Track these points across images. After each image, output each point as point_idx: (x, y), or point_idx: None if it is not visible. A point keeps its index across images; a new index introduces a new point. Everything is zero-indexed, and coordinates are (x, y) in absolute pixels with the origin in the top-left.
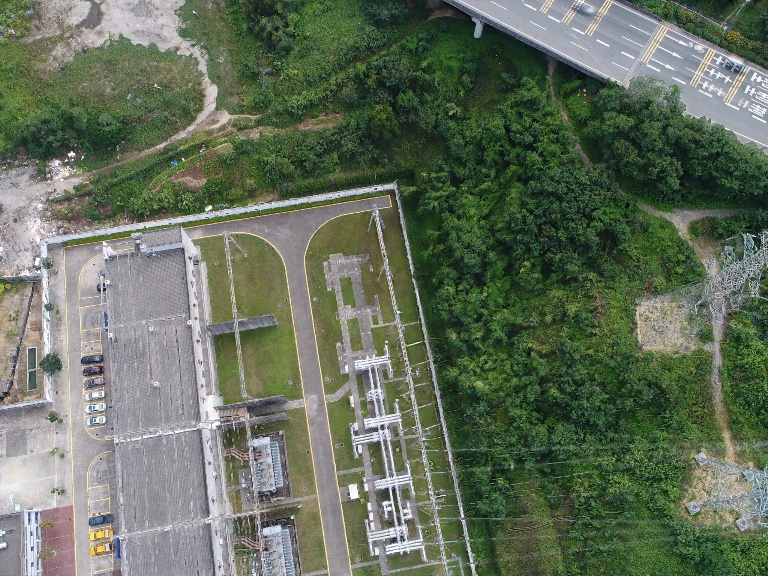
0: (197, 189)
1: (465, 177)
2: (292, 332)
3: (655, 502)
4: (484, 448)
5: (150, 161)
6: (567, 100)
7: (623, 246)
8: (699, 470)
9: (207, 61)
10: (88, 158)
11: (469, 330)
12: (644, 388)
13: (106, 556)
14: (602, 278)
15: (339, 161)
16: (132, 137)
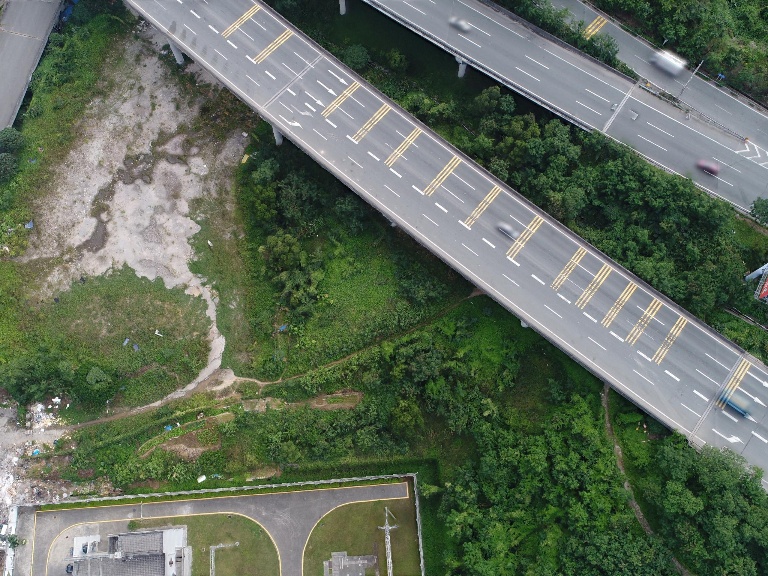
0: (190, 459)
1: (495, 502)
2: None
3: None
4: None
5: (141, 422)
6: (623, 431)
7: None
8: None
9: (217, 305)
10: (74, 407)
11: None
12: None
13: None
14: None
15: (353, 445)
16: (124, 389)
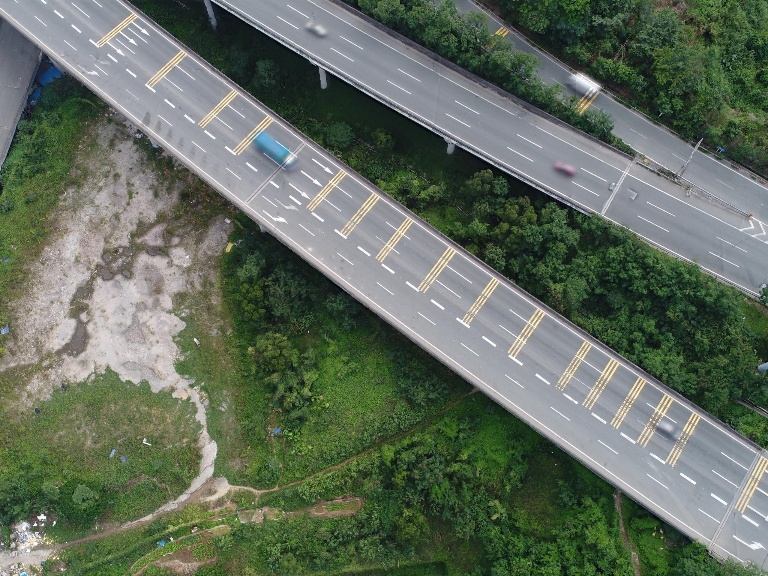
0: (186, 575)
1: None
2: None
3: None
4: None
5: (132, 539)
6: (639, 536)
7: None
8: None
9: (207, 408)
10: (60, 525)
11: None
12: None
13: None
14: None
15: (356, 553)
16: (113, 504)
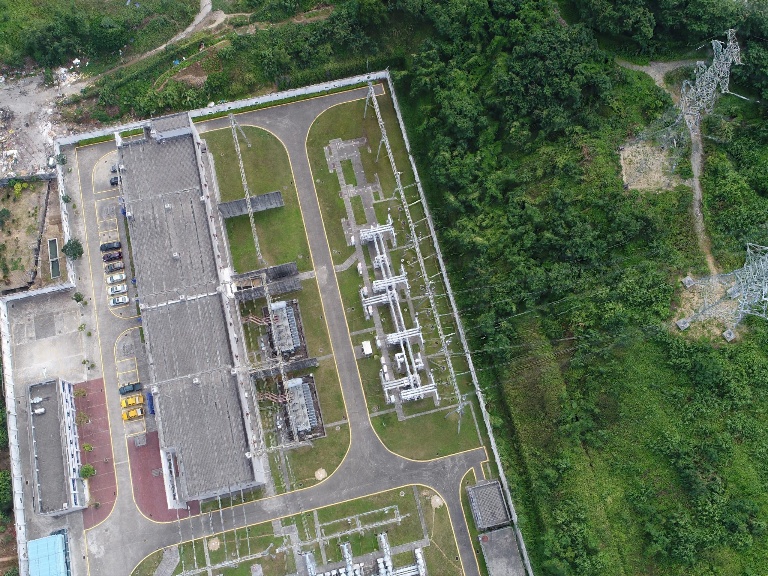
0: (199, 86)
1: (453, 53)
2: (299, 211)
3: (648, 322)
4: (487, 297)
5: (153, 62)
6: None
7: (604, 94)
8: (686, 292)
9: None
10: (93, 64)
11: (466, 191)
12: (632, 221)
13: (138, 421)
14: (587, 130)
15: (333, 51)
16: (134, 41)
